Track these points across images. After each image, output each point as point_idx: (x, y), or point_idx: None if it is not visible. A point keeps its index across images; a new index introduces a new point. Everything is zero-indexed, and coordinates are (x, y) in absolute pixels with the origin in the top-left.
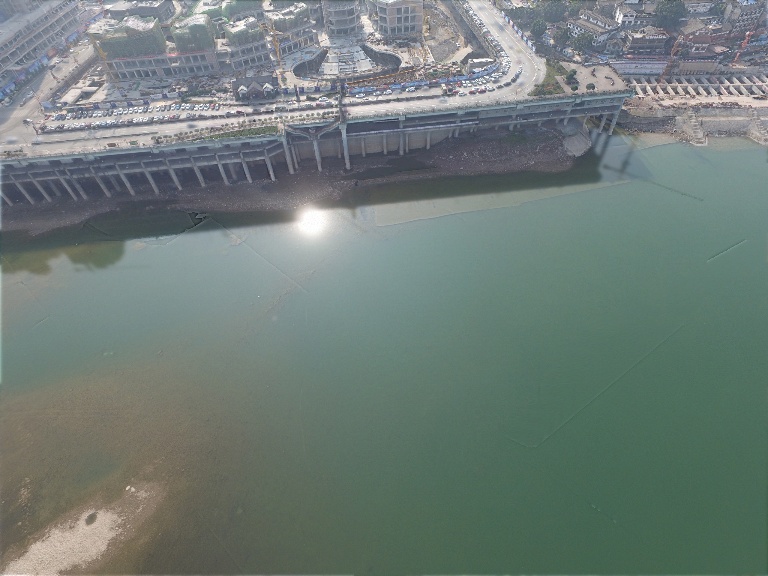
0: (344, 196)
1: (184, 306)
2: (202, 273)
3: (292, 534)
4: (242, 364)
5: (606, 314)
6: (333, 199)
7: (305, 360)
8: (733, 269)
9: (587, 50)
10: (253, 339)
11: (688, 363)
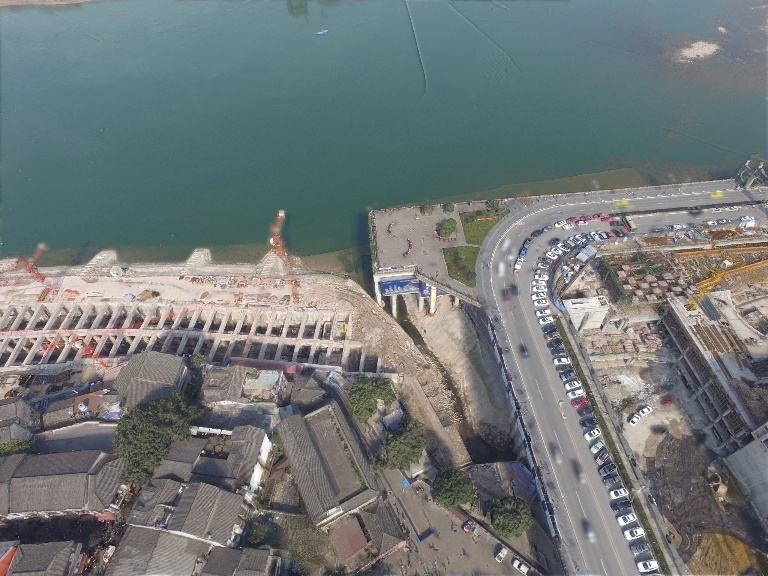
0: None
1: (750, 125)
2: (761, 140)
3: (606, 56)
4: (676, 96)
5: (467, 80)
6: None
7: (638, 98)
8: None
9: None
10: (680, 105)
11: None
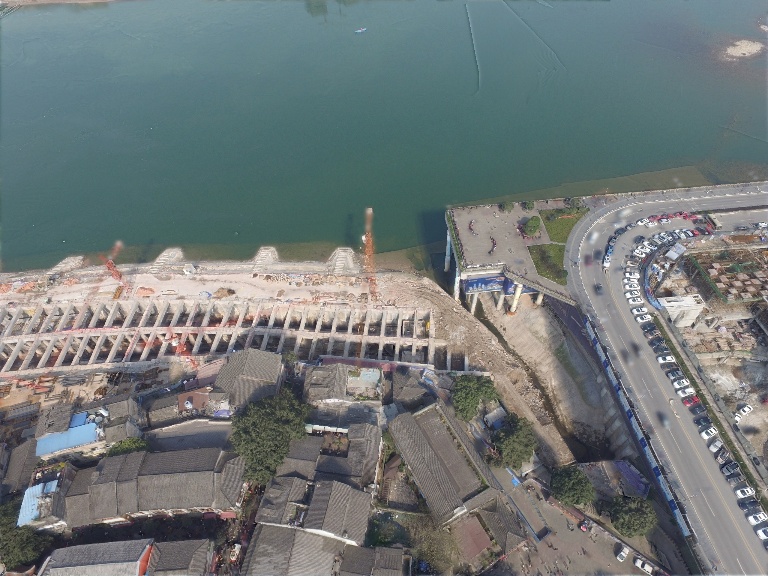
0: None
1: None
2: None
3: None
4: (727, 94)
5: (519, 78)
6: None
7: (688, 97)
8: (493, 4)
9: (454, 417)
10: (732, 103)
11: (462, 96)
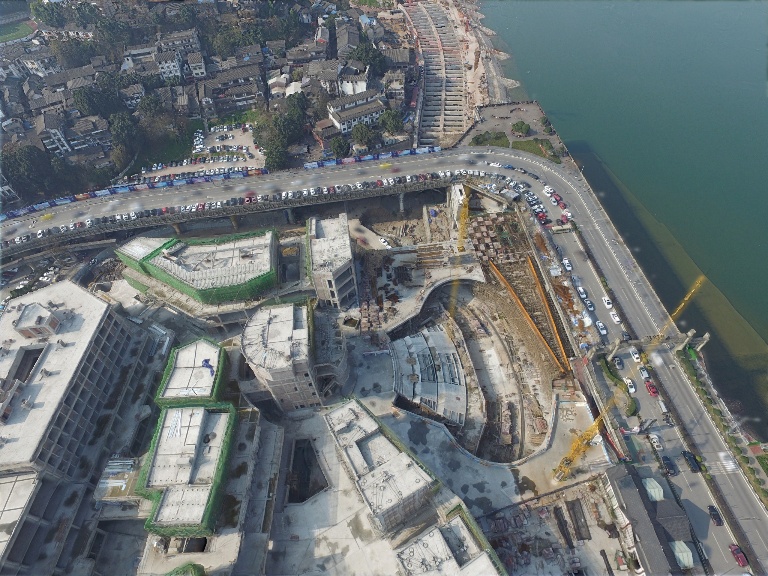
0: (729, 395)
1: None
2: None
3: None
4: None
5: None
6: (744, 410)
7: None
8: None
9: None
10: None
11: None
